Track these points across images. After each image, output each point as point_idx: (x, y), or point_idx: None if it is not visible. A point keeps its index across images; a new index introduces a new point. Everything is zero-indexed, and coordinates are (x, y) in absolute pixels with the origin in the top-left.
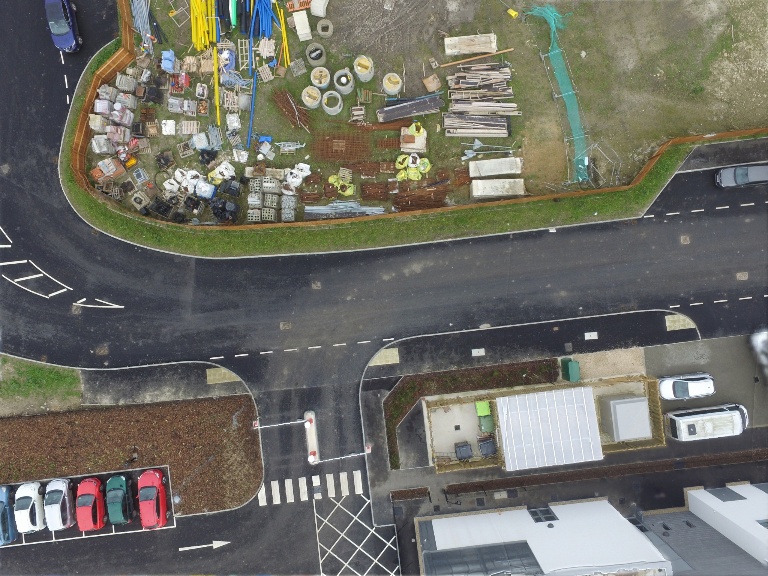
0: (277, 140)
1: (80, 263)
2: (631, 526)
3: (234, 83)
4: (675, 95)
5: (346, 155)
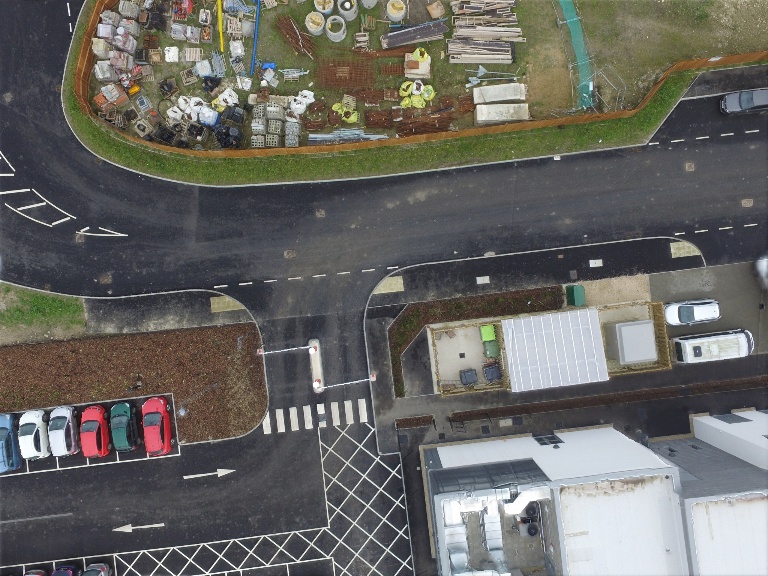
0: (281, 67)
1: (83, 192)
2: (637, 444)
3: (237, 9)
4: (680, 22)
5: (350, 82)
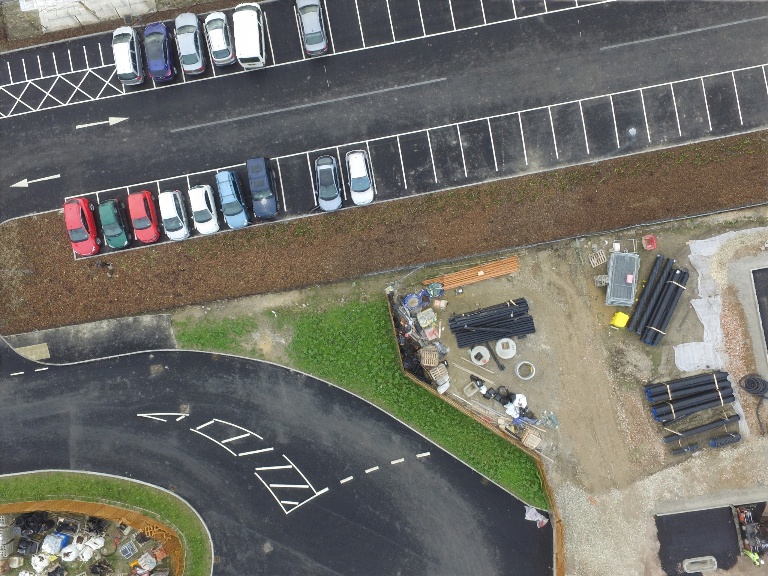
0: None
1: (185, 456)
2: None
3: None
4: None
5: None
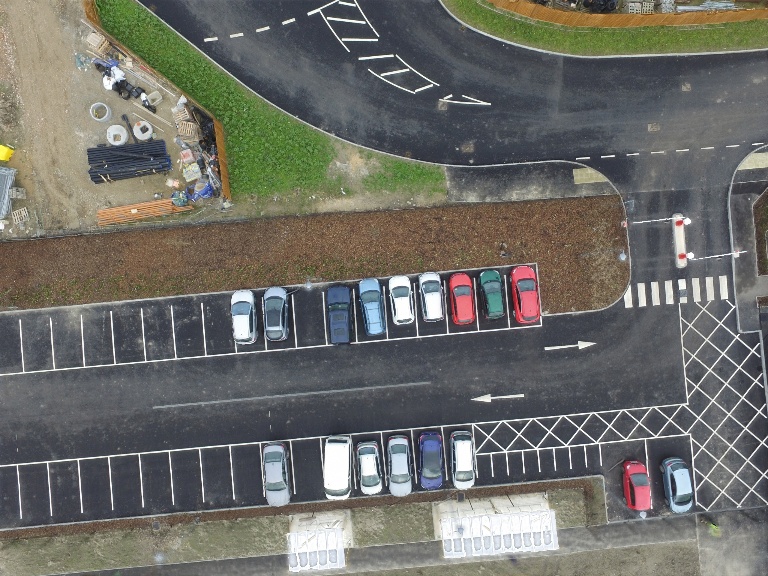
0: None
1: (447, 59)
2: None
3: None
4: None
5: None
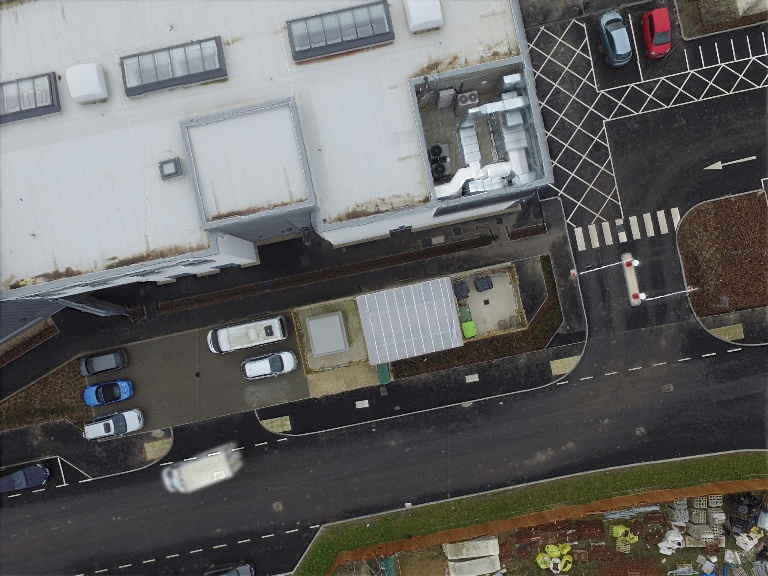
0: (696, 575)
1: None
2: None
3: None
4: None
5: (626, 567)
